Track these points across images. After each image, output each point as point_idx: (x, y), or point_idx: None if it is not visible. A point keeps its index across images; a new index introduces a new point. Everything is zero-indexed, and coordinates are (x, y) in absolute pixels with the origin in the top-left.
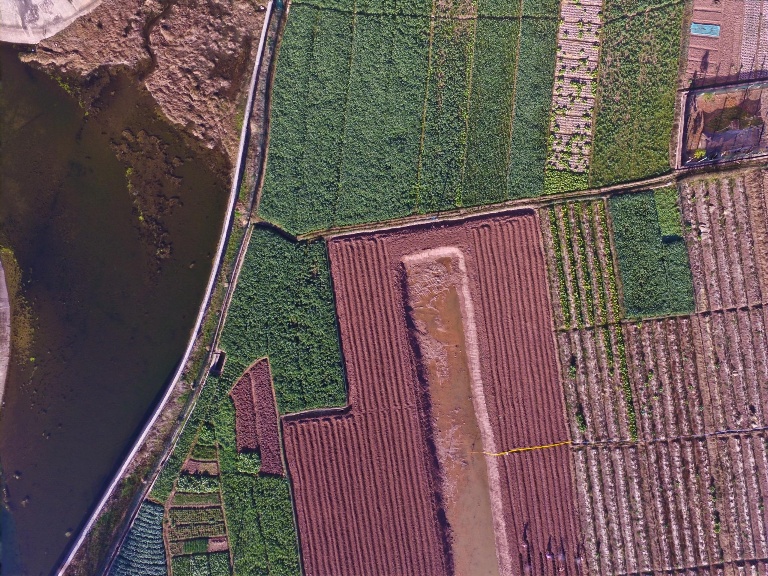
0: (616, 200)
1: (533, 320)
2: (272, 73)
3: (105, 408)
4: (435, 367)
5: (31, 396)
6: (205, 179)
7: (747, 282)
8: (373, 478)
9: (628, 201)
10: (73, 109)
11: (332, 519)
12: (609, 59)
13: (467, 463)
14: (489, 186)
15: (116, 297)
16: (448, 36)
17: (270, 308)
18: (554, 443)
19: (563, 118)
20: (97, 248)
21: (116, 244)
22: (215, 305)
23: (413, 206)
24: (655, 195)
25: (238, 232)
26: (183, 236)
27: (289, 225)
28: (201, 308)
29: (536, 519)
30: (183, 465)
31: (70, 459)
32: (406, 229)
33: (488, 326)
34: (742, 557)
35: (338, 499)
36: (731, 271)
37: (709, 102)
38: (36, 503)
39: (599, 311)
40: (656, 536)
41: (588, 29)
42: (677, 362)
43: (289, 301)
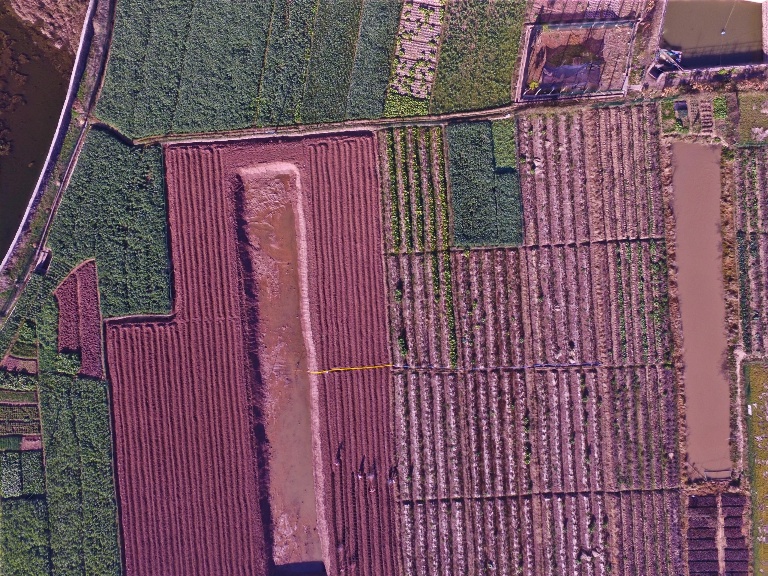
0: (453, 127)
1: (363, 241)
2: None
3: None
4: (266, 283)
5: None
6: (51, 79)
7: (577, 219)
8: (191, 387)
9: (464, 129)
10: None
11: (148, 425)
12: None
13: (291, 381)
14: (329, 104)
15: None
16: None
17: (100, 209)
18: (375, 365)
19: (409, 43)
20: None
21: None
22: (45, 203)
23: (252, 118)
24: (493, 126)
25: (74, 131)
26: (24, 134)
27: (125, 127)
28: None
29: (351, 439)
30: (2, 361)
31: None
32: (244, 141)
33: (317, 244)
34: (550, 490)
35: (155, 406)
36: (561, 207)
37: (553, 38)
38: None
39: (429, 237)
40: (468, 463)
41: None
42: (502, 293)
43: (120, 204)
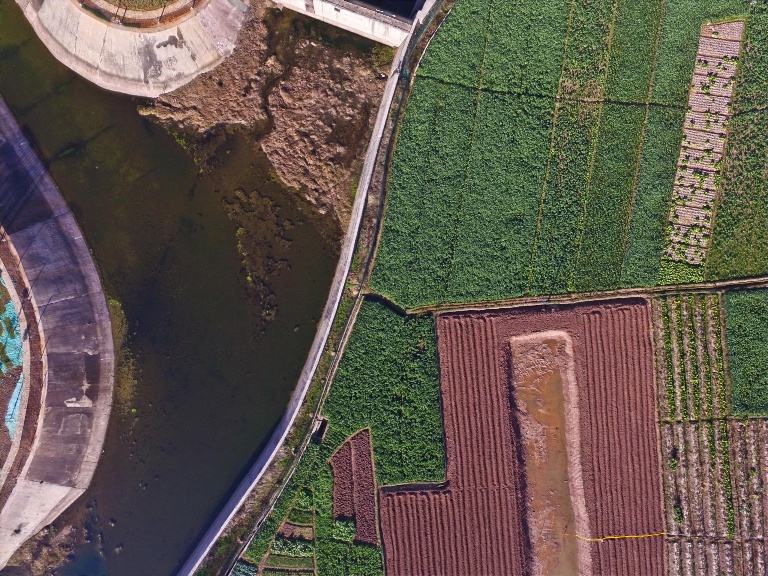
0: (732, 296)
1: (637, 410)
2: (392, 144)
3: (202, 463)
4: (533, 448)
5: (130, 446)
6: (314, 243)
7: None
8: (467, 555)
9: (744, 298)
10: (188, 165)
11: None
12: (734, 152)
13: (559, 545)
14: (603, 273)
15: (219, 354)
16: (572, 118)
17: (376, 380)
18: (649, 533)
19: (683, 209)
20: (203, 305)
21: (222, 302)
22: (320, 373)
23: (525, 288)
24: None
25: (348, 301)
26: (289, 299)
27: (400, 299)
28: (307, 375)
29: None
30: (279, 528)
31: (165, 510)
32: (516, 310)
33: (592, 413)
34: None
35: (430, 572)
36: None
37: None
38: (129, 551)
39: (705, 405)
40: None
41: (715, 120)
42: None
43: (395, 374)
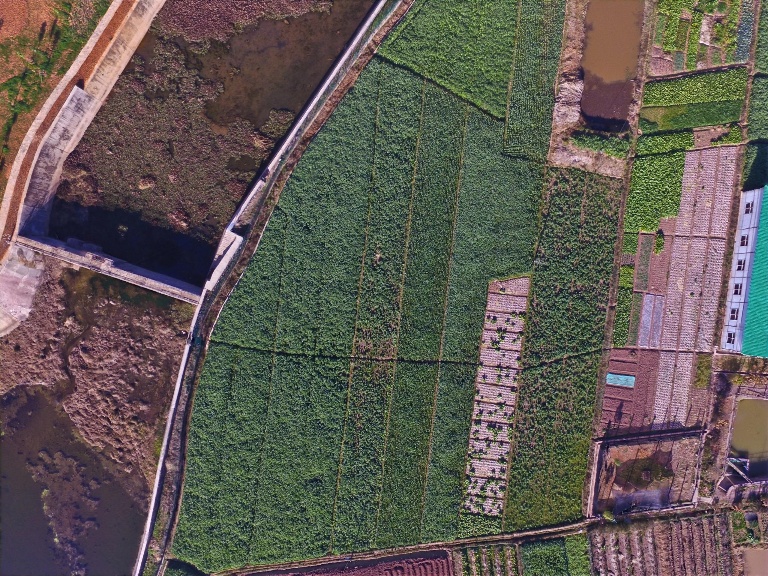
0: (527, 549)
1: None
2: (190, 409)
3: None
4: None
5: None
6: (122, 501)
7: None
8: None
9: (539, 550)
10: None
11: None
12: (526, 405)
13: None
14: (403, 529)
15: None
16: (367, 378)
17: None
18: None
19: (479, 462)
20: (11, 568)
21: (30, 564)
22: None
23: (327, 548)
24: (566, 542)
25: (151, 568)
26: (99, 558)
27: (202, 565)
28: None
29: None
30: None
31: None
32: (320, 568)
33: None
34: None
35: None
36: None
37: (622, 452)
38: None
39: None
40: None
41: (506, 374)
42: None
43: None
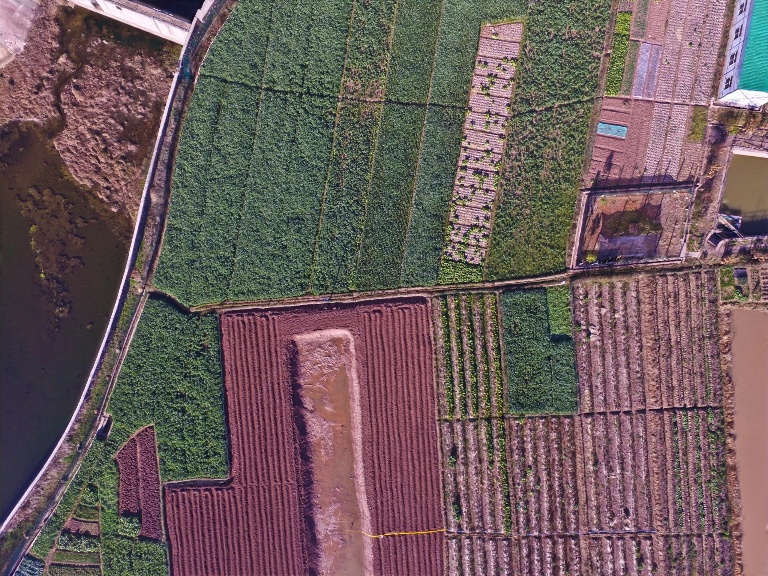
0: (507, 296)
1: (417, 408)
2: (176, 143)
3: None
4: (320, 445)
5: None
6: (108, 241)
7: (633, 386)
8: (249, 550)
9: (519, 298)
10: None
11: None
12: (513, 153)
13: (345, 541)
14: (383, 272)
15: (14, 351)
16: (354, 118)
17: (159, 377)
18: (429, 530)
19: (463, 209)
20: None
21: (17, 299)
22: (106, 370)
23: (306, 286)
24: (548, 293)
25: (133, 299)
26: (83, 296)
27: (182, 297)
28: None
29: None
30: (65, 523)
31: None
32: (299, 308)
33: (372, 411)
34: None
35: (214, 568)
36: (617, 374)
37: (609, 204)
38: None
39: (483, 404)
40: None
41: (495, 121)
42: (556, 460)
43: (178, 372)
